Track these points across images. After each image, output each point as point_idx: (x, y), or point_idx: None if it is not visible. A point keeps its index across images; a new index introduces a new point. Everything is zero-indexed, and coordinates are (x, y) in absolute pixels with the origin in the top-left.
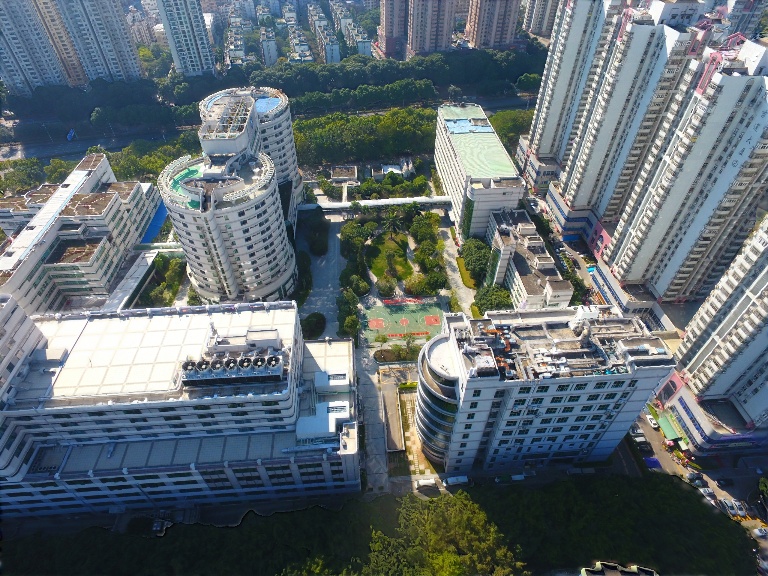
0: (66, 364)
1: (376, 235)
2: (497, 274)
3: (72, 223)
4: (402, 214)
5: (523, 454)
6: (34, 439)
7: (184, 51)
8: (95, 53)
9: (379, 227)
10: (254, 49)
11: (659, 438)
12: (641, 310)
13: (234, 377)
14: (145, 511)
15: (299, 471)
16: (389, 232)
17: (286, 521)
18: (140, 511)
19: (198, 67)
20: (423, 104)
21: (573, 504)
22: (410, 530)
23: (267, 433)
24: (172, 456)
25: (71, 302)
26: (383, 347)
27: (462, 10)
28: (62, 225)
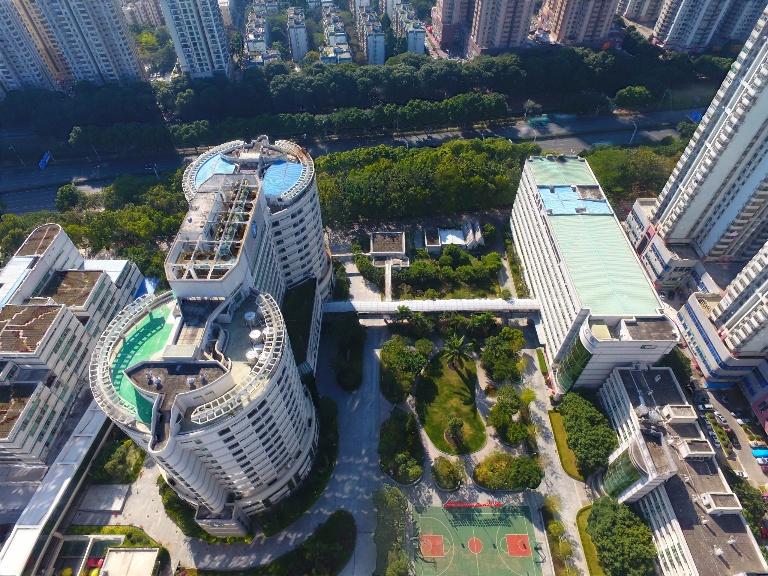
0: None
1: (431, 356)
2: (631, 495)
3: None
4: (470, 329)
5: None
6: None
7: (189, 47)
8: (80, 48)
9: (435, 341)
10: (279, 36)
11: None
12: None
13: None
14: None
15: None
16: None
17: None
18: None
19: (207, 66)
20: (490, 123)
21: None
22: None
23: None
24: None
25: None
26: None
27: None
28: None
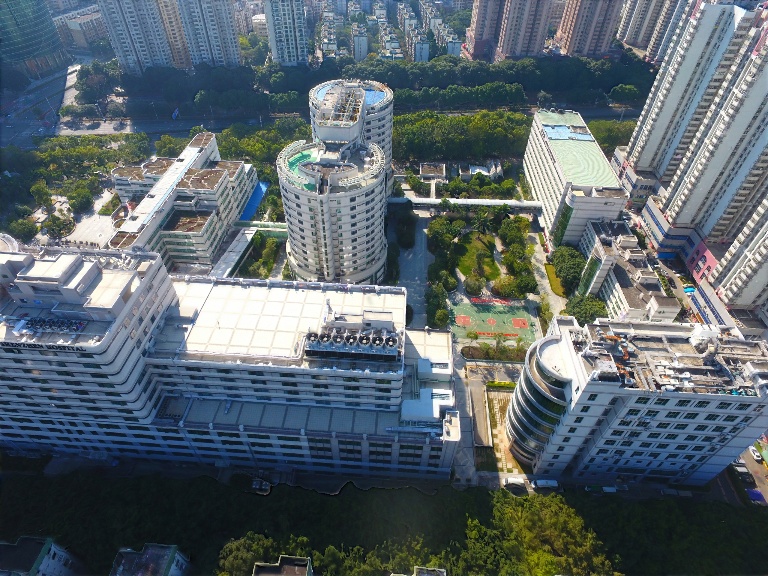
0: (197, 322)
1: (463, 234)
2: (593, 284)
3: (186, 195)
4: (491, 215)
5: (619, 467)
6: (163, 387)
7: (283, 42)
8: (202, 39)
9: (466, 226)
10: (345, 44)
11: (762, 471)
12: (748, 337)
13: (353, 352)
14: (245, 469)
15: (399, 451)
16: (476, 232)
17: (385, 497)
18: (241, 468)
19: (294, 58)
20: (510, 108)
21: (676, 523)
22: (506, 524)
23: (371, 410)
24: (283, 420)
25: (178, 268)
26: (470, 344)
27: (553, 16)
28: (177, 196)
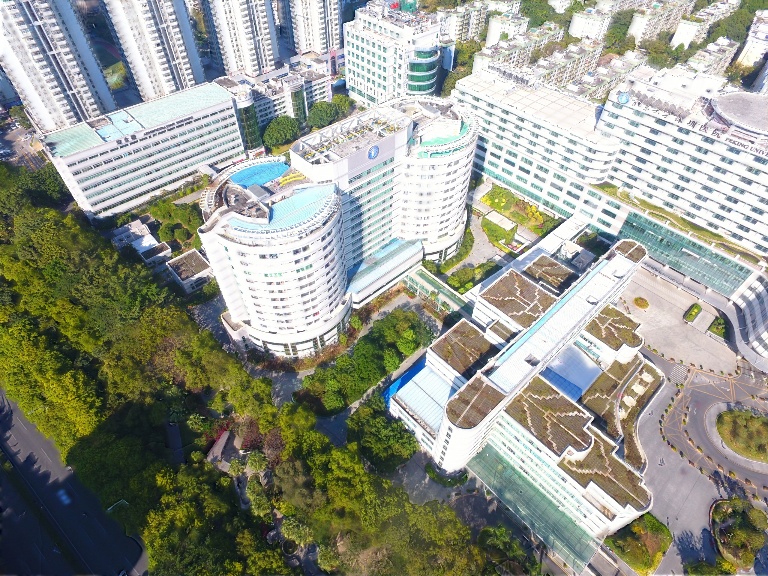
0: None
1: None
2: None
3: None
4: None
5: None
6: None
7: None
8: None
9: None
10: None
11: None
12: None
13: None
14: None
15: None
16: None
17: None
18: None
19: None
20: None
21: None
22: None
23: None
24: None
25: None
26: None
27: None
28: None
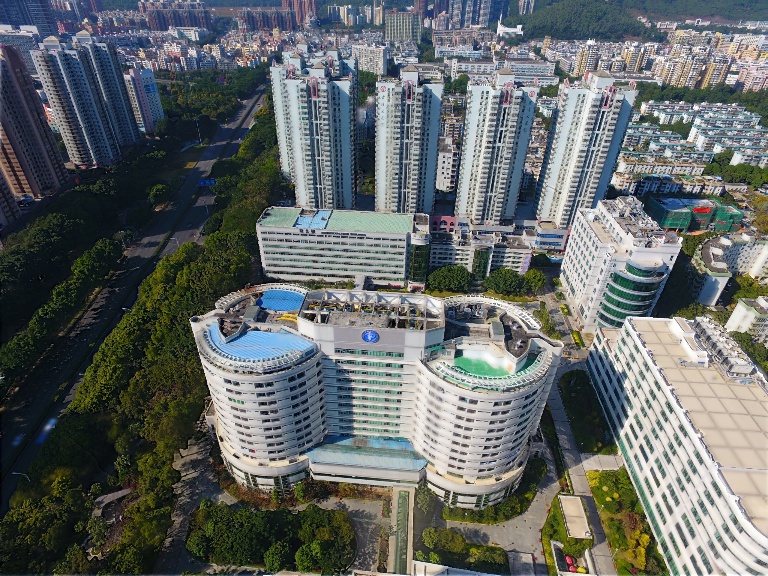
0: None
1: None
2: None
3: None
4: None
5: None
6: None
7: None
8: None
9: None
10: None
11: None
12: None
13: None
14: None
15: None
16: None
17: None
18: None
19: None
20: None
21: None
22: None
23: None
24: None
25: None
26: None
27: None
28: None
